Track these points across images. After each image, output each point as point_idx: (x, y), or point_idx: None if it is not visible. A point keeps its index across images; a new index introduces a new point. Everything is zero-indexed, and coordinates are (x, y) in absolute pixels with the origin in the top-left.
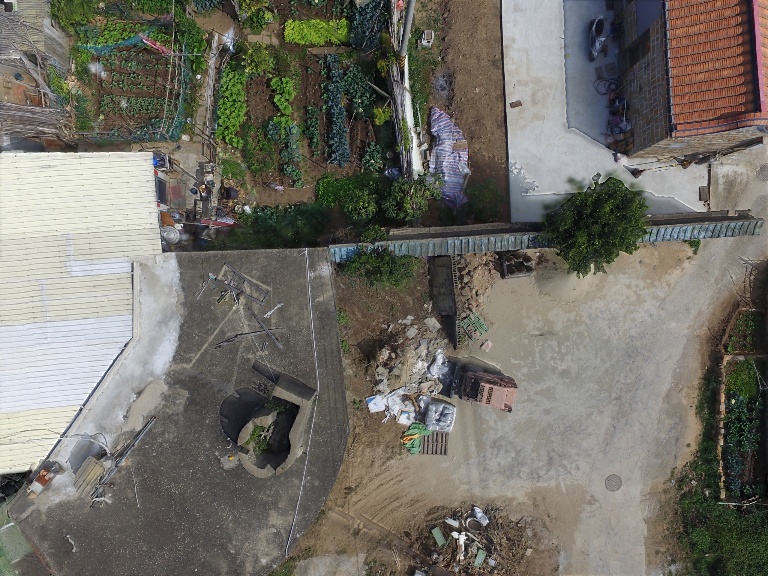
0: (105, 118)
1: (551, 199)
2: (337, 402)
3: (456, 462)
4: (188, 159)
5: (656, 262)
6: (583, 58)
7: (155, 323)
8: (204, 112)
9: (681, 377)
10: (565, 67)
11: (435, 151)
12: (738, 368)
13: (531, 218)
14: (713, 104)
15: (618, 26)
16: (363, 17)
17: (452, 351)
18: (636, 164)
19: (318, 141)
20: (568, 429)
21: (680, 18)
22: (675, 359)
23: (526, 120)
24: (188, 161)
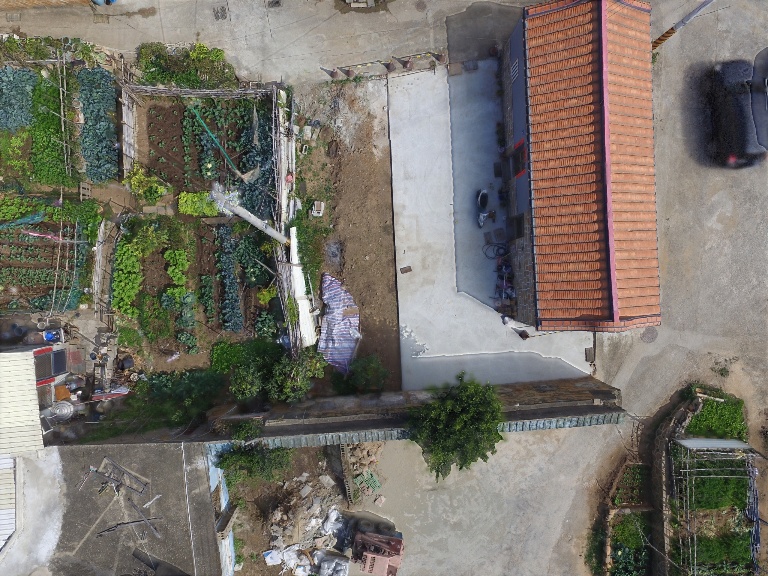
0: (4, 289)
1: (441, 361)
2: None
3: None
4: (87, 325)
5: None
6: (472, 224)
7: (39, 513)
8: (102, 281)
9: (570, 528)
10: (454, 233)
11: (325, 319)
12: (625, 519)
13: (422, 379)
14: (574, 304)
15: (505, 194)
16: (252, 193)
17: (346, 506)
18: (524, 326)
19: (212, 309)
20: None
21: (545, 217)
22: (564, 511)
23: (416, 285)
24: (87, 327)
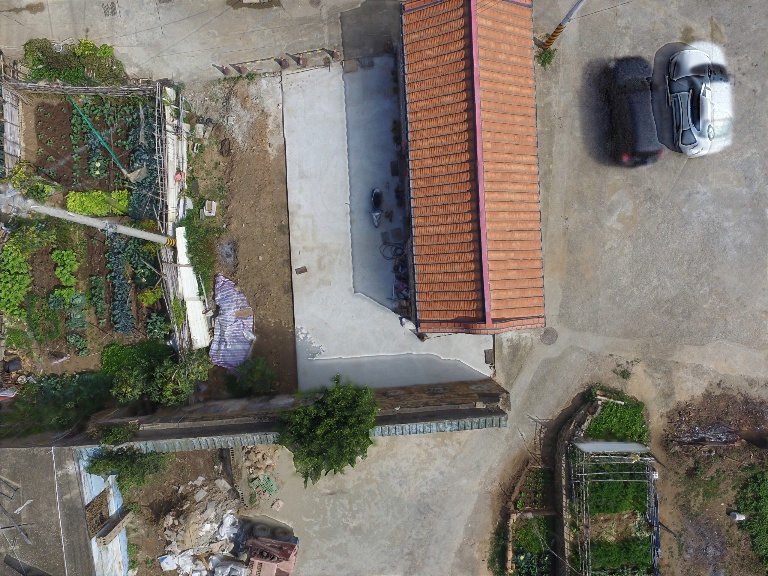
0: None
1: (338, 363)
2: None
3: None
4: None
5: None
6: (369, 223)
7: None
8: None
9: (473, 532)
10: (351, 232)
11: (218, 320)
12: (528, 523)
13: (318, 382)
14: (451, 306)
15: (402, 193)
16: (139, 193)
17: (243, 510)
18: None
19: (102, 310)
20: None
21: (423, 217)
22: (466, 515)
23: (312, 285)
24: None
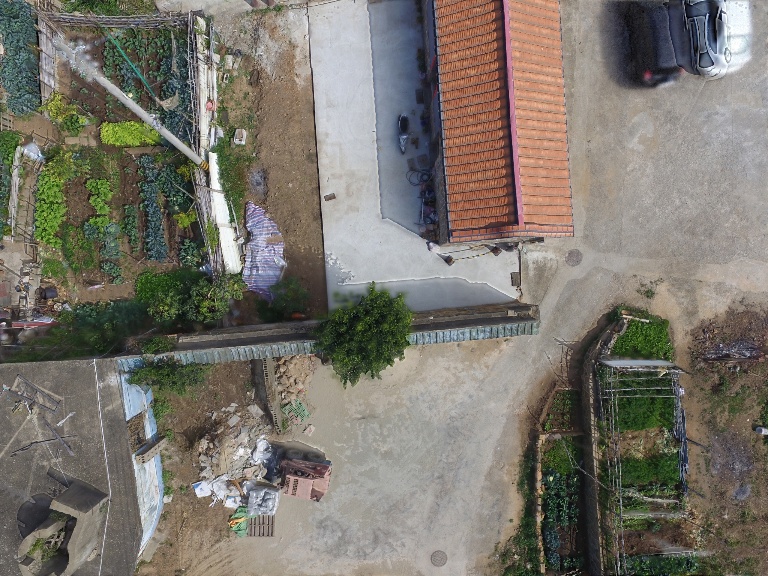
0: None
1: (367, 288)
2: (129, 506)
3: (284, 543)
4: (12, 258)
5: (474, 345)
6: (395, 150)
7: None
8: (25, 212)
9: (502, 455)
10: (378, 160)
11: (249, 246)
12: (557, 445)
13: (348, 307)
14: (482, 213)
15: (427, 119)
16: (171, 120)
17: (276, 436)
18: (449, 252)
19: (136, 238)
20: (393, 508)
21: (453, 128)
22: (495, 438)
23: (341, 212)
24: (12, 260)
